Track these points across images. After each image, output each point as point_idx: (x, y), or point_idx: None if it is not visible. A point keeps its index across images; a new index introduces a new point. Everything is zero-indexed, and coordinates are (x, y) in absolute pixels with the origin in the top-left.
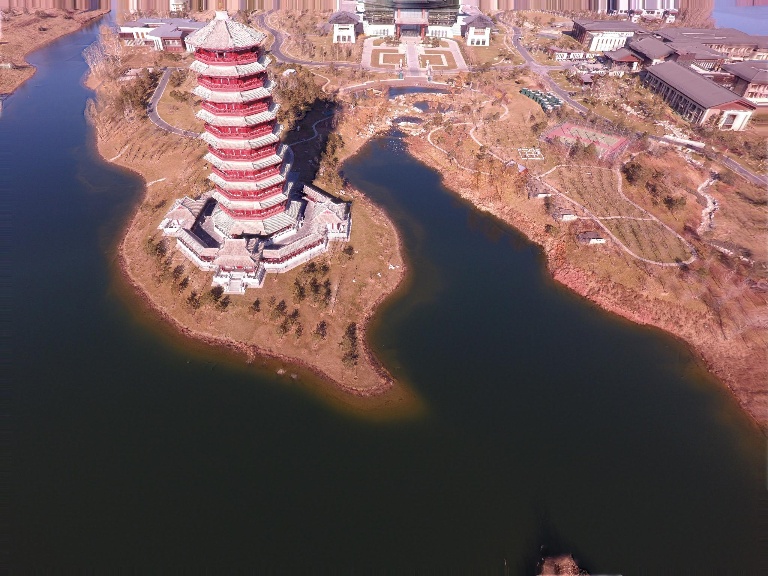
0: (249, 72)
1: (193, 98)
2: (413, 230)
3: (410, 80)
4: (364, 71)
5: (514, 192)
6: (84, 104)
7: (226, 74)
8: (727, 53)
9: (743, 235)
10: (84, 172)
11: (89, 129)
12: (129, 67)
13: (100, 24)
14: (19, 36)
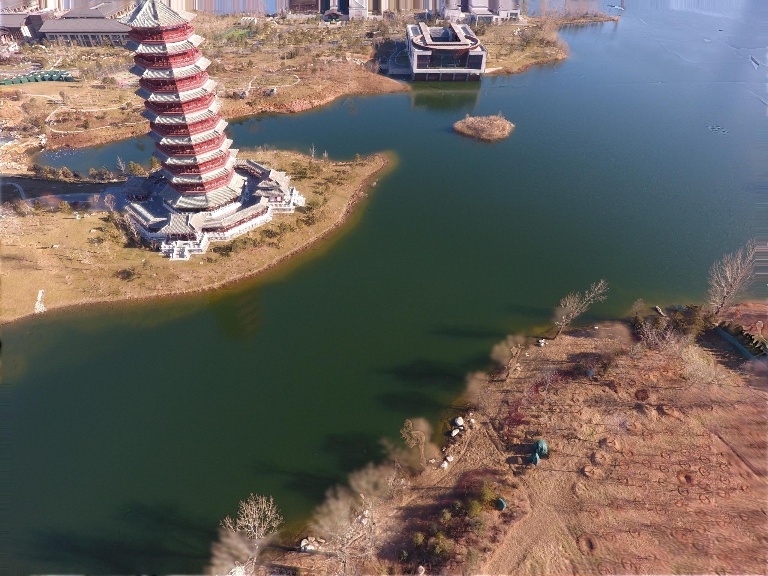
0: None
1: None
2: None
3: None
4: None
5: None
6: None
7: (200, 41)
8: None
9: (276, 64)
10: None
11: None
12: None
13: None
14: None
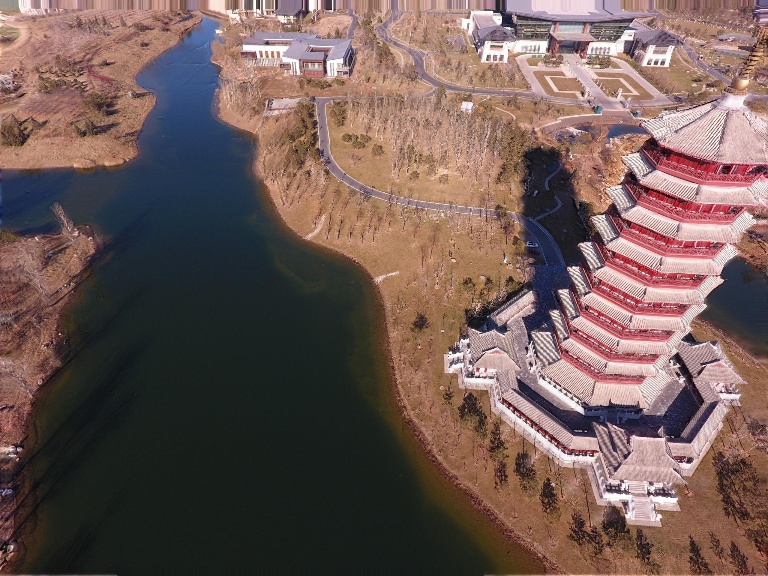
0: (759, 195)
1: (370, 143)
2: None
3: (610, 115)
4: (546, 102)
5: None
6: (231, 146)
7: (734, 202)
8: None
9: None
10: (280, 256)
11: (256, 185)
12: (270, 97)
13: (212, 40)
14: (124, 54)
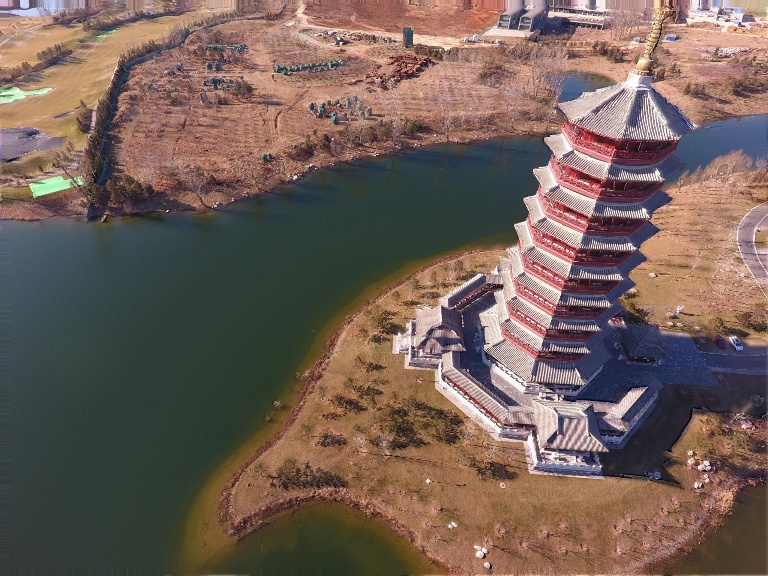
0: (579, 167)
1: None
2: None
3: None
4: None
5: None
6: None
7: (555, 152)
8: None
9: None
10: None
11: None
12: None
13: None
14: None
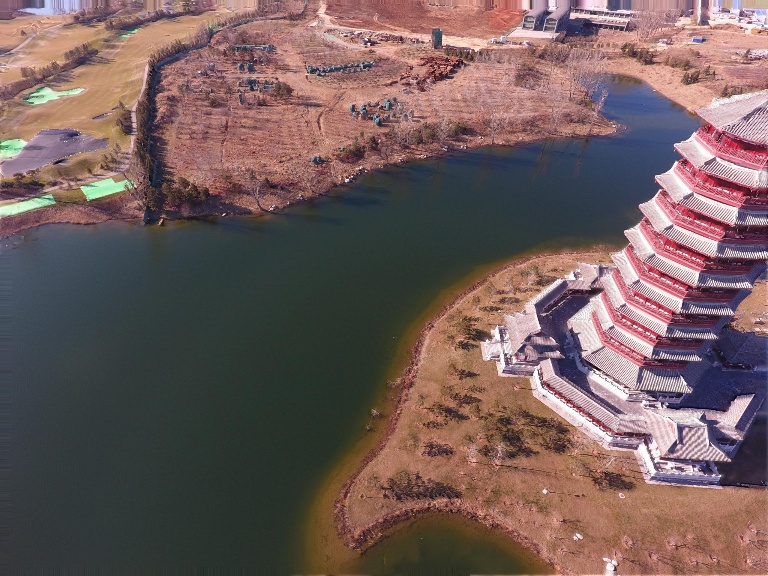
0: (724, 175)
1: None
2: None
3: None
4: None
5: None
6: None
7: (691, 159)
8: None
9: None
10: None
11: None
12: None
13: None
14: None
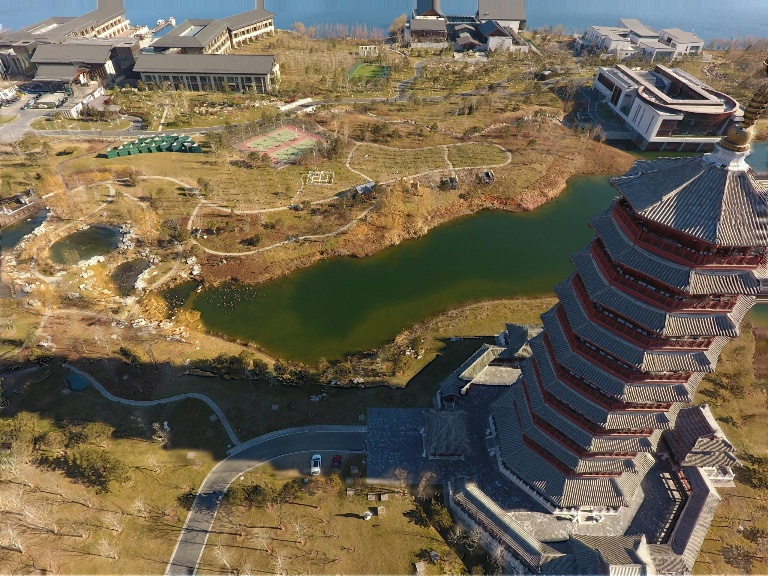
0: None
1: None
2: (477, 289)
3: None
4: None
5: (405, 203)
6: None
7: None
8: (84, 37)
9: (456, 123)
10: None
11: None
12: None
13: None
14: None
